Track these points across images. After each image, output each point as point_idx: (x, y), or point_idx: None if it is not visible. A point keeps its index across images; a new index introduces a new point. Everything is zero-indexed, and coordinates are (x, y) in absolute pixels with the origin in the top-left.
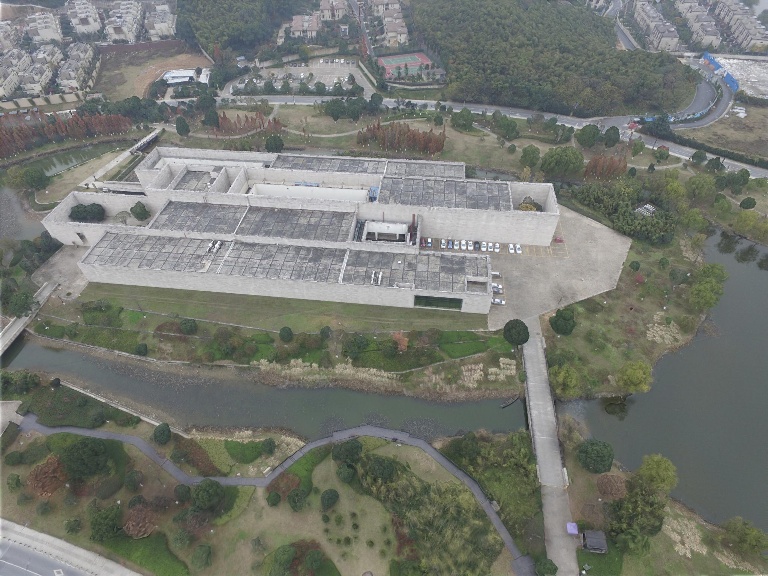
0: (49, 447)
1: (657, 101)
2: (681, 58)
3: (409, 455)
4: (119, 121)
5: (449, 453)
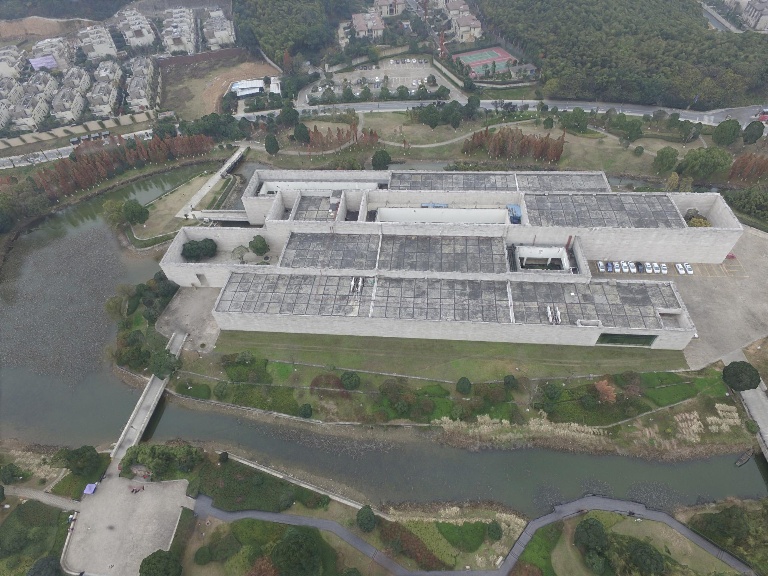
0: (238, 539)
1: None
2: None
3: (655, 533)
4: (202, 141)
5: (705, 530)
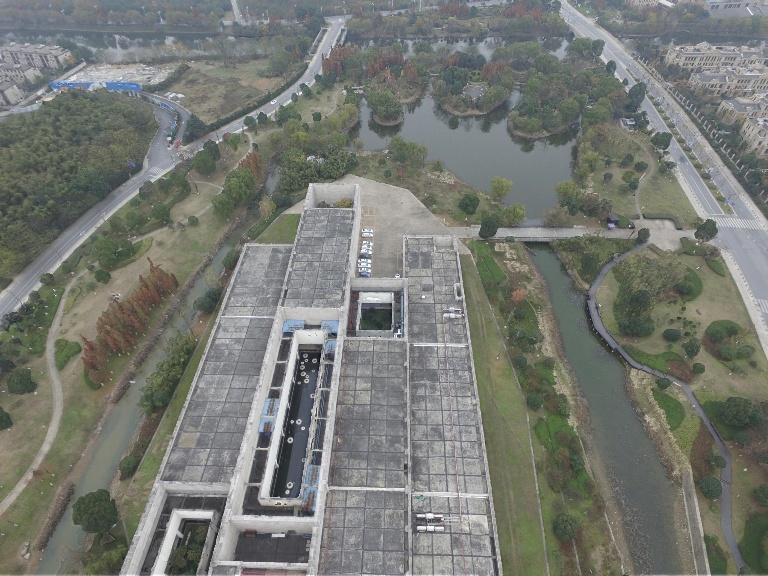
0: None
1: (153, 119)
2: (42, 98)
3: (605, 299)
4: None
5: None
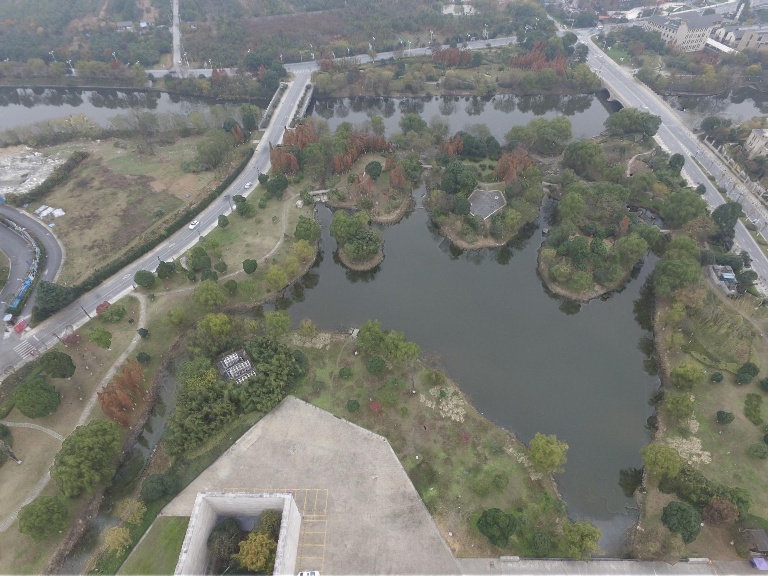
0: None
1: None
2: None
3: None
4: None
5: None
